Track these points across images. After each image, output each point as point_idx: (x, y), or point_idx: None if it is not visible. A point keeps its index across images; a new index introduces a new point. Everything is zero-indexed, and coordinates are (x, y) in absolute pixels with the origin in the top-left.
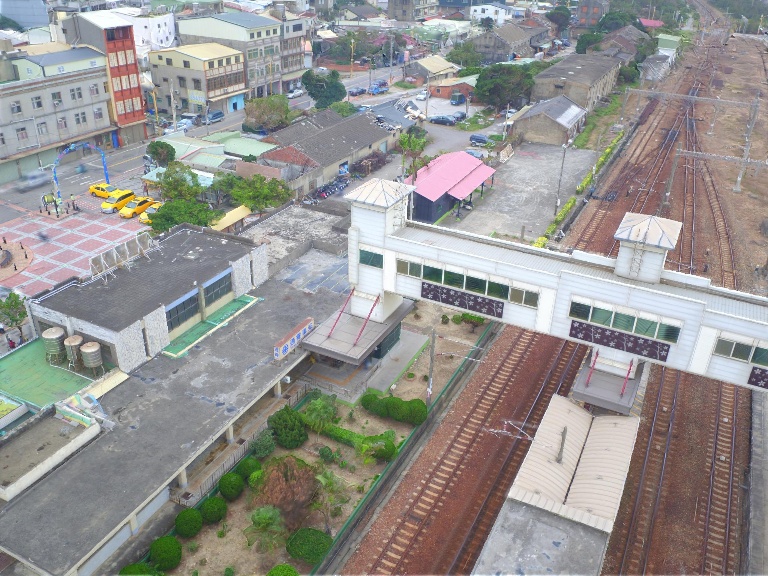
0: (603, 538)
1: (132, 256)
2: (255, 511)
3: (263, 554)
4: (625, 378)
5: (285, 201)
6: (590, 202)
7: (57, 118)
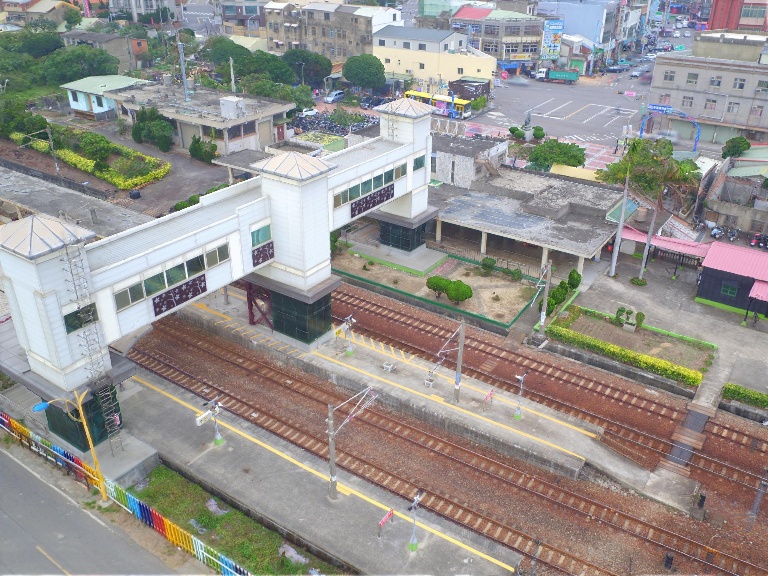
0: None
1: (451, 133)
2: None
3: None
4: None
5: (641, 193)
6: None
7: (754, 104)
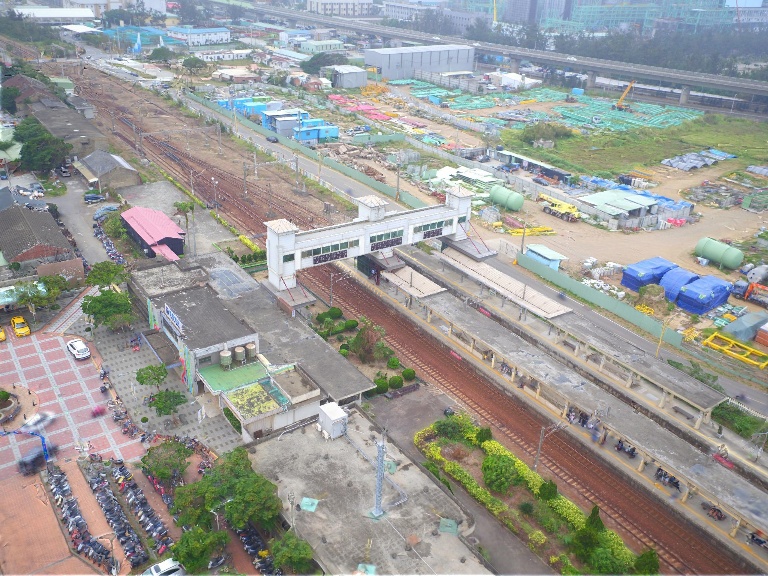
0: (446, 292)
1: None
2: (352, 363)
3: (375, 367)
4: (391, 257)
5: None
6: (214, 211)
7: None
